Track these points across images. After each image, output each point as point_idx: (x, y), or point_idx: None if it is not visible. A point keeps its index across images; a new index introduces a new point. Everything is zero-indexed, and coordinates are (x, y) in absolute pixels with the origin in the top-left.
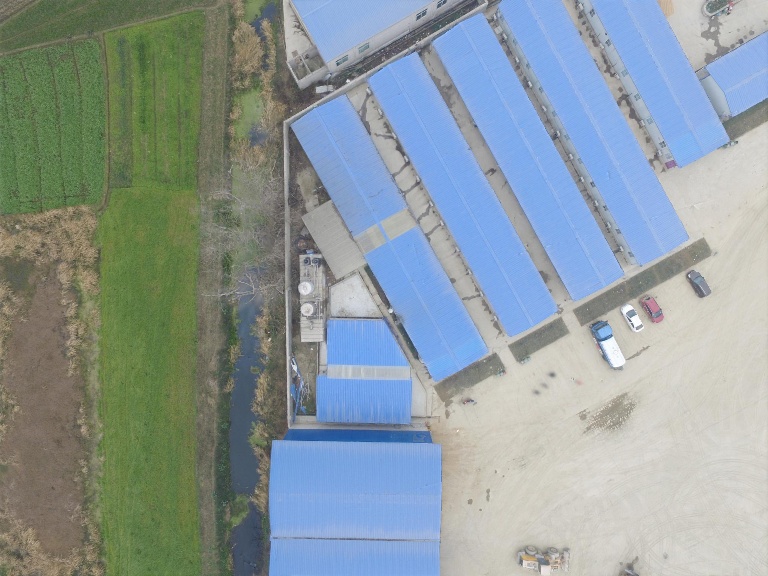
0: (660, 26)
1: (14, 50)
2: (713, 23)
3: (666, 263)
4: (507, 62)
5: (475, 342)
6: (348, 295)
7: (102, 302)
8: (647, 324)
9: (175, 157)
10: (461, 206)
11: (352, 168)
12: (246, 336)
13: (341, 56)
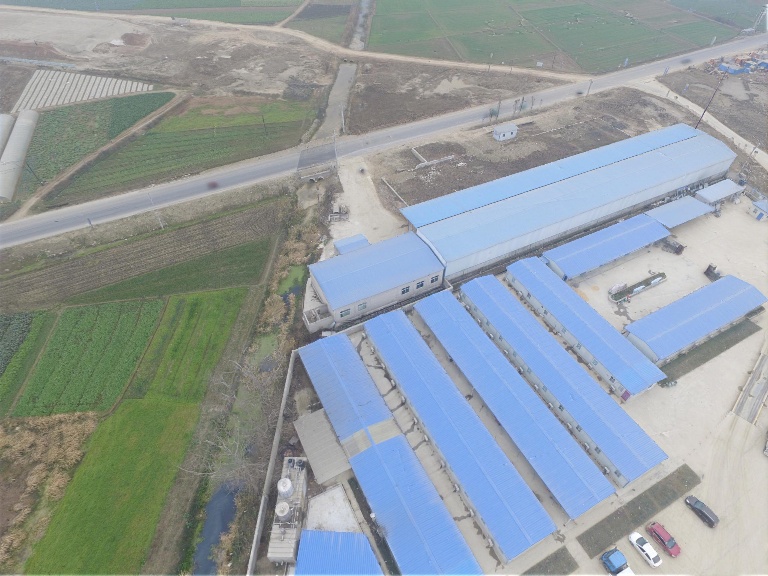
0: (580, 302)
1: (98, 303)
2: (620, 307)
3: (658, 488)
4: (471, 318)
5: (469, 565)
6: (328, 509)
7: (58, 509)
8: (665, 559)
9: (192, 377)
10: (442, 417)
11: (345, 382)
12: (203, 560)
13: (345, 308)
